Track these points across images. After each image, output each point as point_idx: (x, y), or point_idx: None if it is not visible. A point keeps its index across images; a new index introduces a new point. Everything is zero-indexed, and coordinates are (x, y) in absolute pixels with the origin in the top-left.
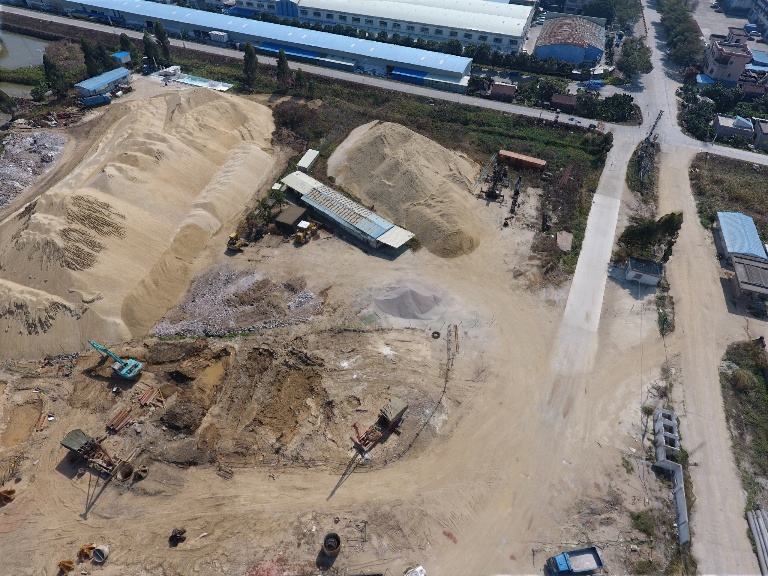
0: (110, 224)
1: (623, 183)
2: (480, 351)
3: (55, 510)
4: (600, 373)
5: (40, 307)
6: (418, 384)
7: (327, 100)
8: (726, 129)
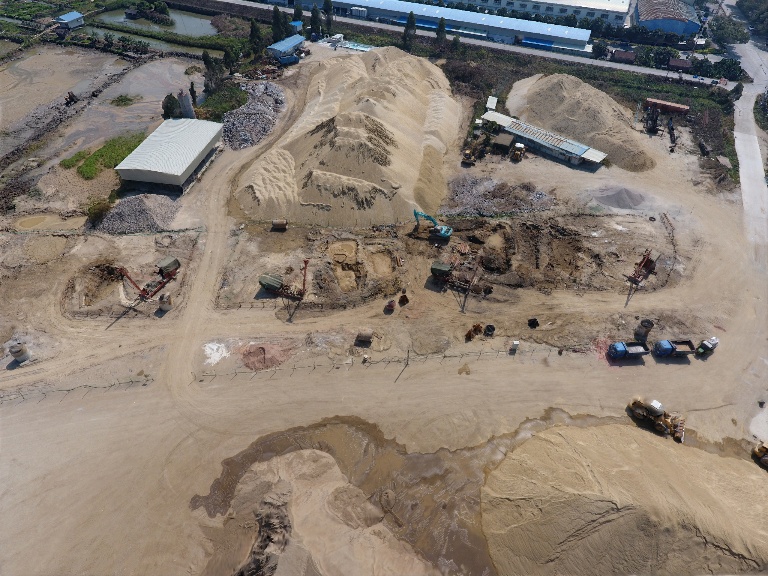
0: (388, 137)
1: (754, 124)
2: (690, 229)
3: (440, 308)
4: None
5: (366, 190)
6: (654, 247)
7: (479, 62)
8: None
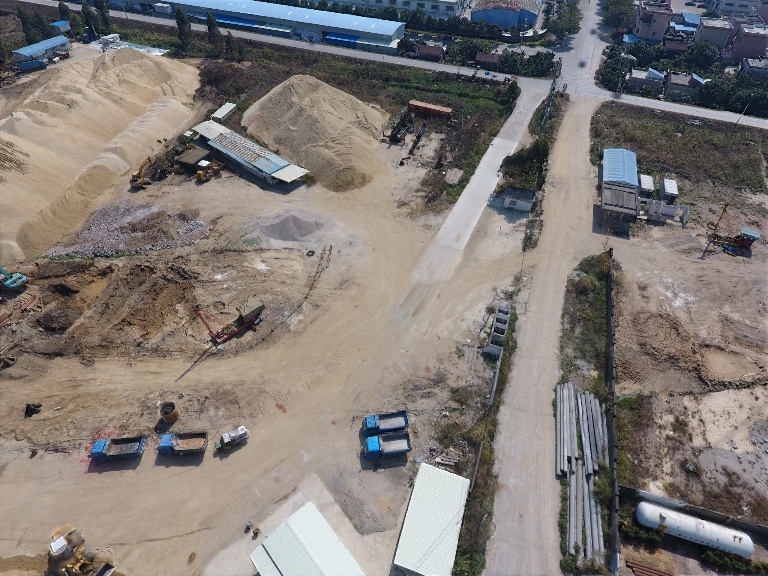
0: (12, 160)
1: (525, 128)
2: (348, 266)
3: None
4: (456, 282)
5: None
6: (283, 292)
7: (257, 62)
8: (638, 81)
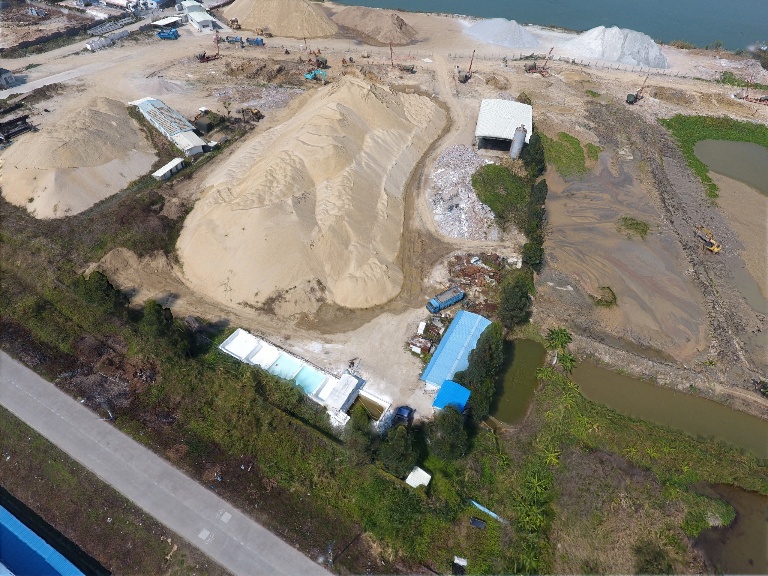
0: None
1: None
2: None
3: None
4: None
5: None
6: None
7: None
8: None
